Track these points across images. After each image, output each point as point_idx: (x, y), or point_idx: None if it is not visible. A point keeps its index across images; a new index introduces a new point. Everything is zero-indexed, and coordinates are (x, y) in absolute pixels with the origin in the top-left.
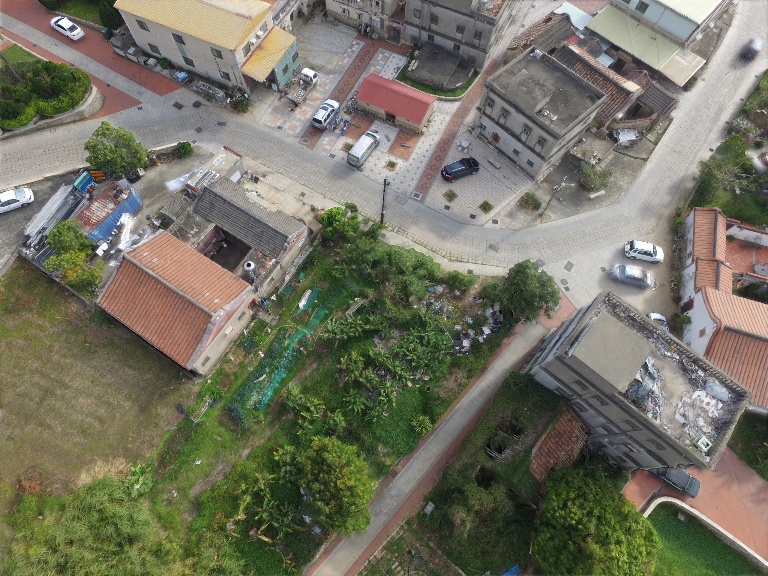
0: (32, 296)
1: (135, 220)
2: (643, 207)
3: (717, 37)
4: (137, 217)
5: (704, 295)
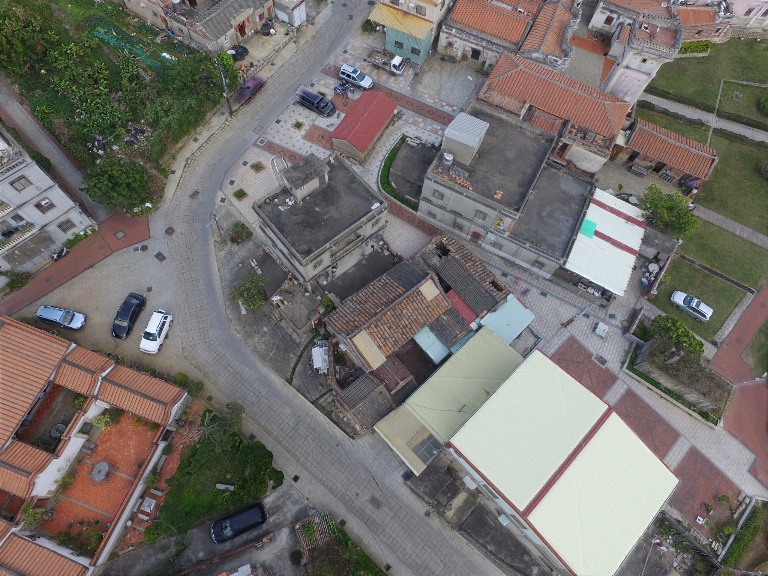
0: None
1: None
2: (219, 355)
3: (518, 567)
4: None
5: (58, 337)
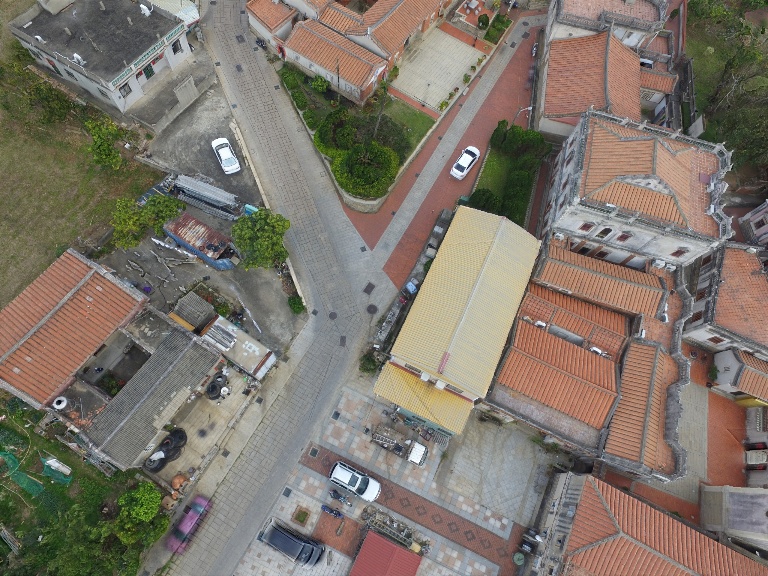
0: (123, 192)
1: (205, 266)
2: None
3: None
4: (209, 267)
5: None
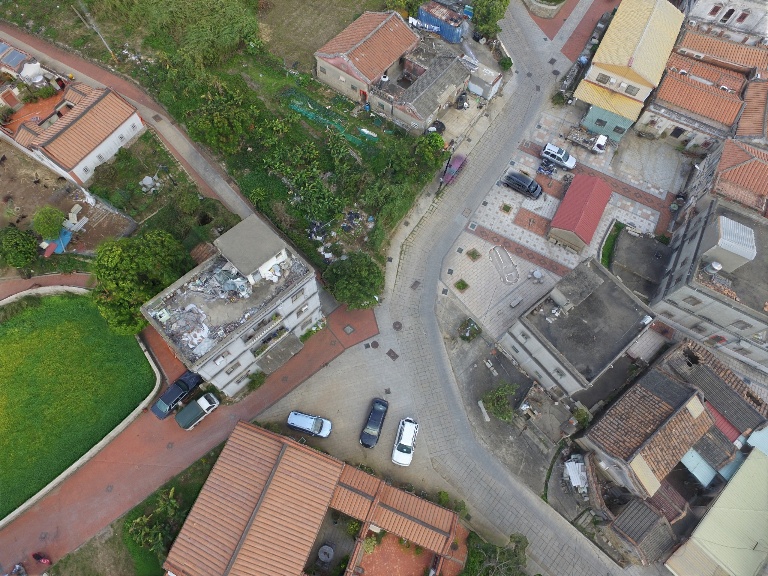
0: None
1: (441, 41)
2: (470, 467)
3: None
4: (443, 42)
5: (332, 457)
